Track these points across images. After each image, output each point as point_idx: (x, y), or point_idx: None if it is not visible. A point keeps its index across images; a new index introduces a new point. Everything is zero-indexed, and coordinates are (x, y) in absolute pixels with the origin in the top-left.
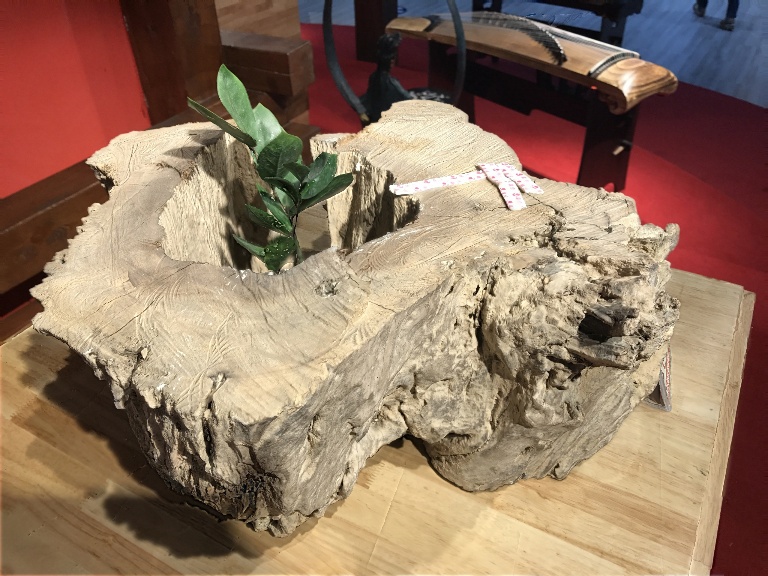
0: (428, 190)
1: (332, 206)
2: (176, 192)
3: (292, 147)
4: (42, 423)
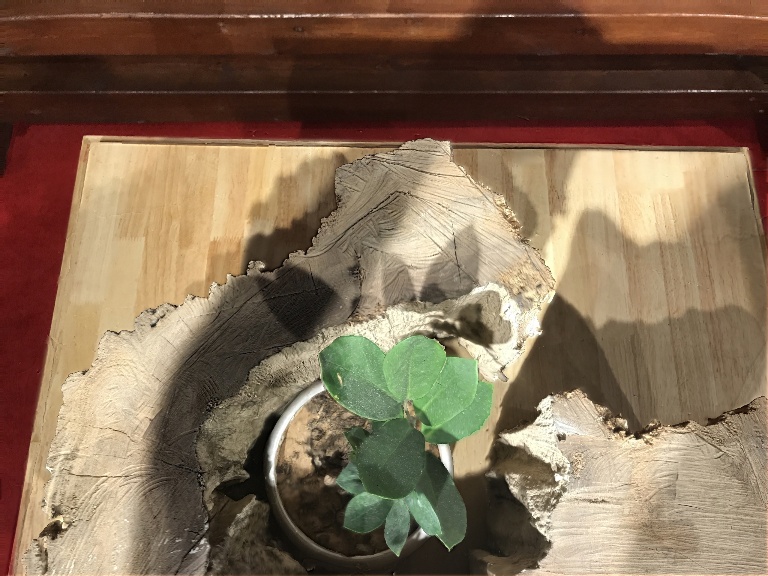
0: None
1: (527, 436)
2: (326, 330)
3: (392, 487)
4: (220, 270)
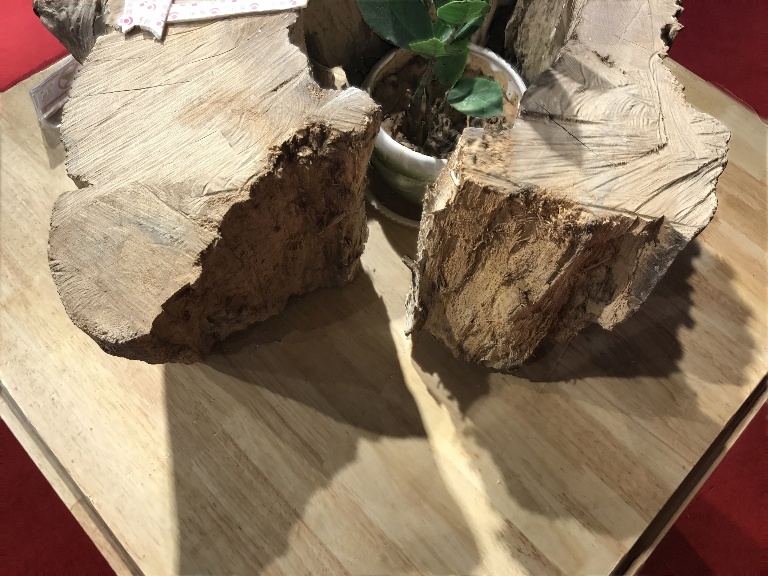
0: None
1: None
2: None
3: None
4: None
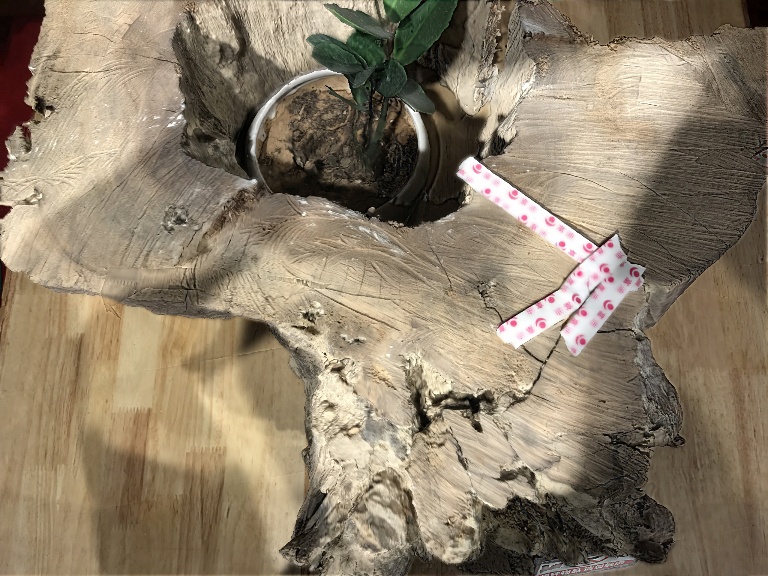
0: (496, 205)
1: (499, 89)
2: None
3: None
4: None
